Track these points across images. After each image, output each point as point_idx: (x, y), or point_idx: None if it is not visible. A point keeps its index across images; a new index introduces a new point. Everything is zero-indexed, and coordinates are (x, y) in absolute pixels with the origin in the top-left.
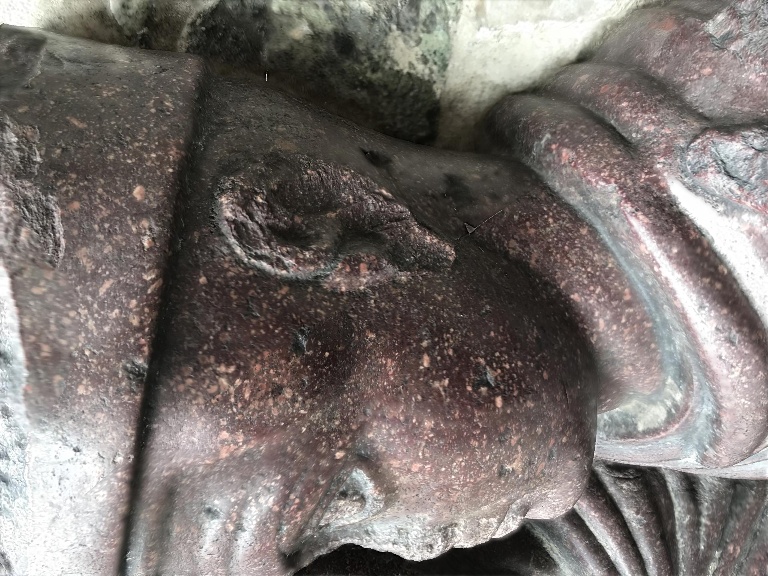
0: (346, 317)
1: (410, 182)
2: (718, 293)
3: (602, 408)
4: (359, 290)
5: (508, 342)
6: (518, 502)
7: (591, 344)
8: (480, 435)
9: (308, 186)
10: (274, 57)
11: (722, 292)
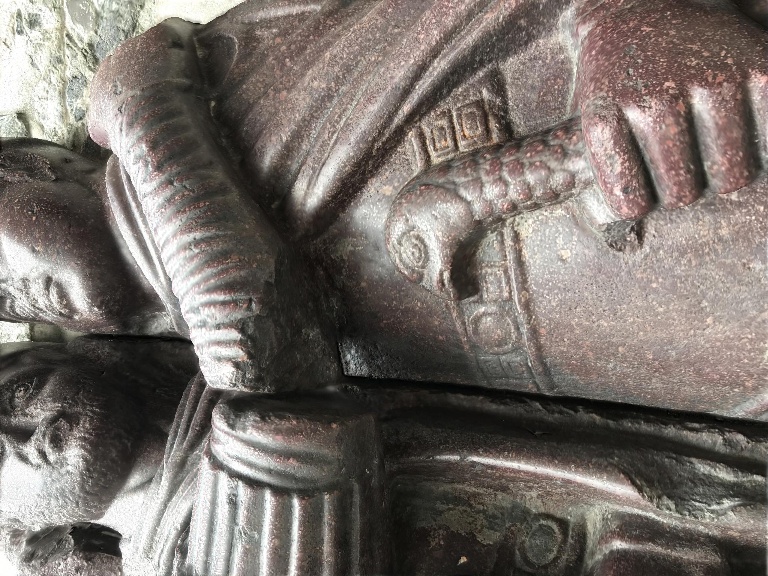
0: (4, 187)
1: (71, 166)
2: (113, 182)
3: (140, 274)
4: (14, 182)
5: (50, 202)
6: (54, 279)
7: (109, 224)
8: (24, 228)
9: (25, 159)
10: (102, 152)
11: (114, 182)
